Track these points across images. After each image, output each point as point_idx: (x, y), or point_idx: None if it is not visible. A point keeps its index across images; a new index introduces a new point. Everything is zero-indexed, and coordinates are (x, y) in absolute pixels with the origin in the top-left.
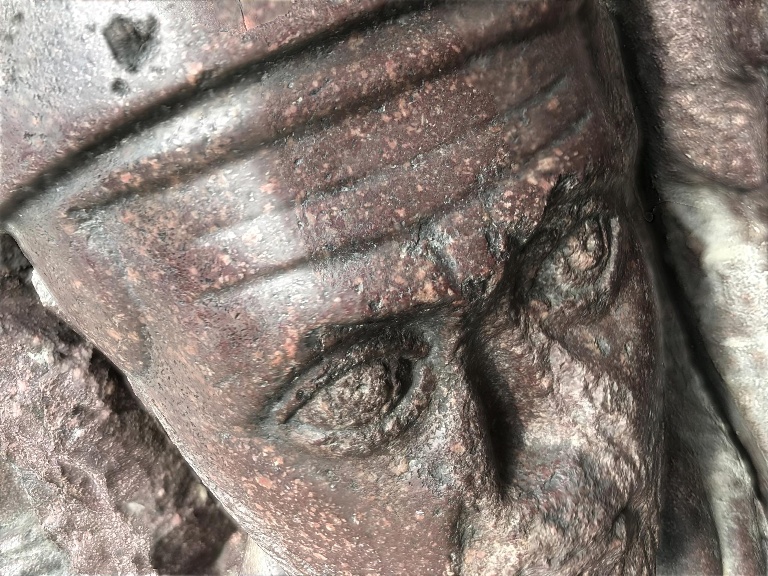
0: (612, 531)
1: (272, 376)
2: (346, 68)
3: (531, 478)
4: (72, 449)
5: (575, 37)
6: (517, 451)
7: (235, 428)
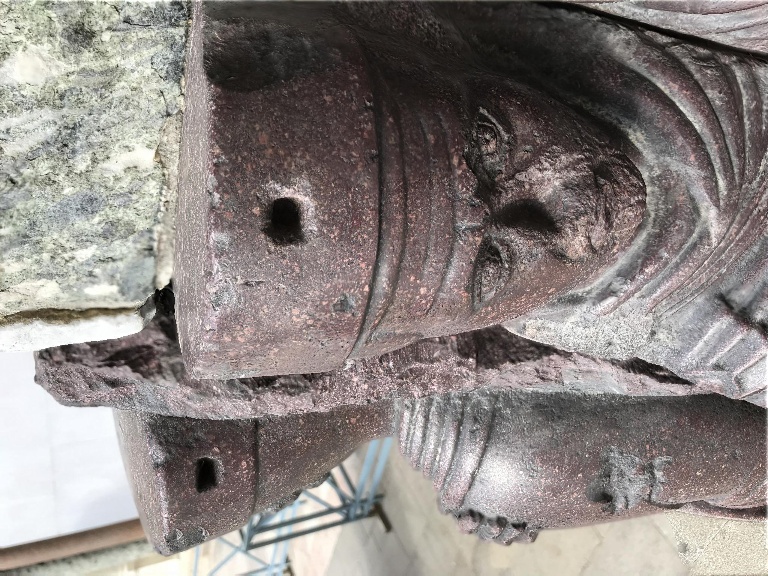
0: (599, 187)
1: (468, 303)
2: (392, 234)
3: (558, 212)
4: (396, 371)
5: (400, 95)
6: (544, 208)
7: (469, 318)
